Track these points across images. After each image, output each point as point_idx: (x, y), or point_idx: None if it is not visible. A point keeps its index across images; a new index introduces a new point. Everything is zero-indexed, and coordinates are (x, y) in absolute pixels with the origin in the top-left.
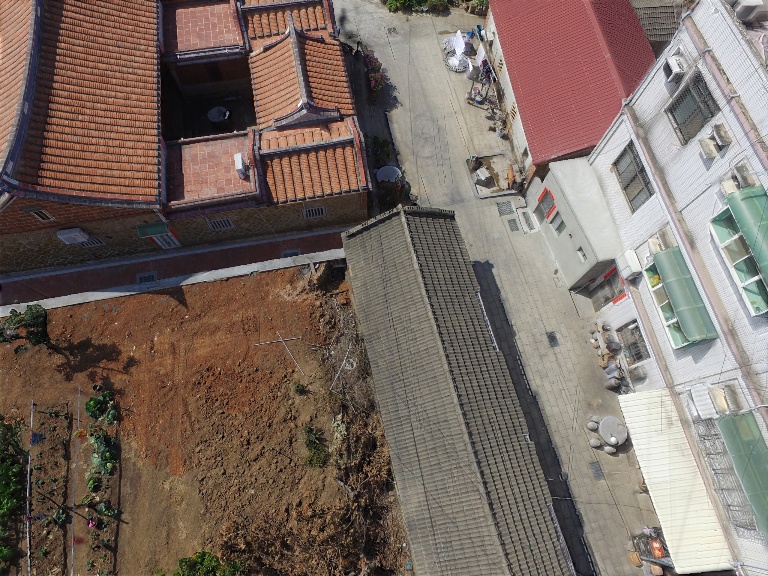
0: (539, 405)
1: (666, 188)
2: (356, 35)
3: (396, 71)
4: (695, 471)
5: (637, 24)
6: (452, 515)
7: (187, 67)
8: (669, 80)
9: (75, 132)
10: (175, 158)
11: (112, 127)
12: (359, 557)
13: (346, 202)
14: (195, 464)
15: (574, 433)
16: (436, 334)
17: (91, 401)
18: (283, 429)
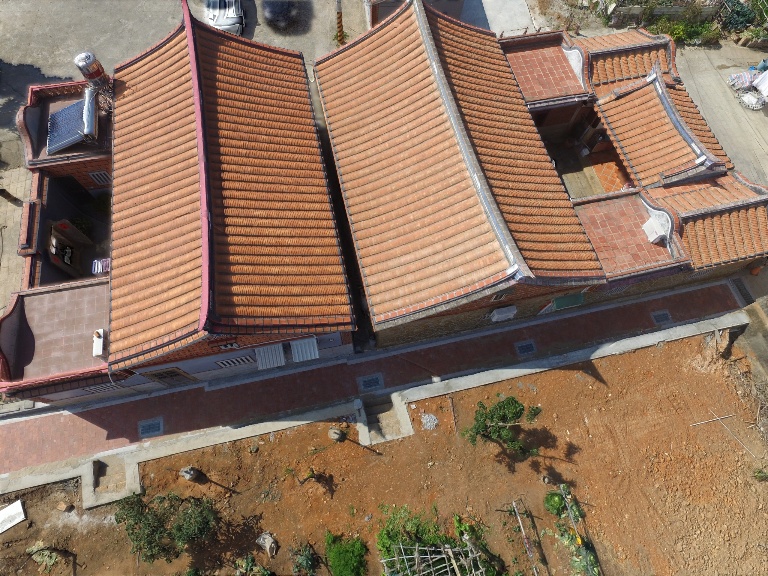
0: None
1: None
2: None
3: None
4: None
5: None
6: None
7: None
8: None
9: (515, 202)
10: None
11: (535, 193)
12: None
13: (738, 262)
14: (683, 565)
15: None
16: None
17: (554, 497)
18: (758, 521)
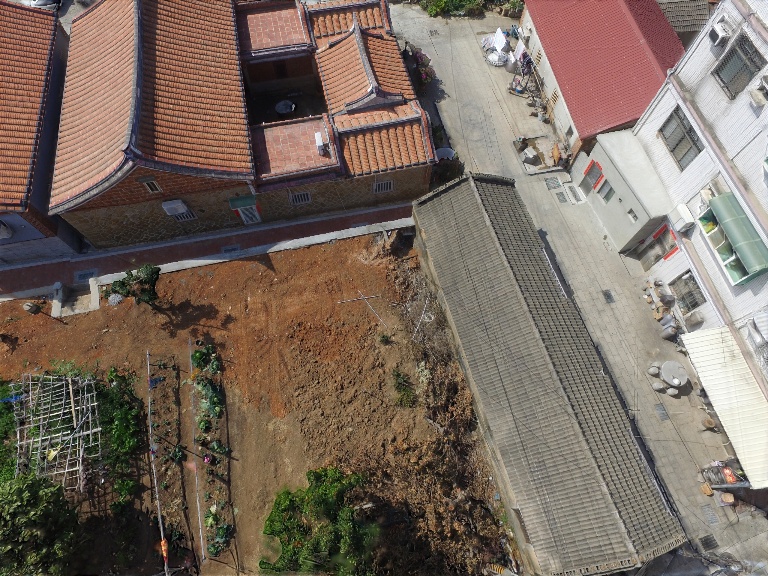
0: (602, 354)
1: (716, 141)
2: (401, 37)
3: (441, 67)
4: (760, 396)
5: (663, 16)
6: (542, 437)
7: (258, 65)
8: (716, 44)
9: (178, 114)
10: (259, 140)
11: (208, 111)
12: (452, 487)
13: (413, 176)
14: (295, 407)
15: (637, 378)
16: (513, 280)
17: (197, 353)
18: (372, 375)
